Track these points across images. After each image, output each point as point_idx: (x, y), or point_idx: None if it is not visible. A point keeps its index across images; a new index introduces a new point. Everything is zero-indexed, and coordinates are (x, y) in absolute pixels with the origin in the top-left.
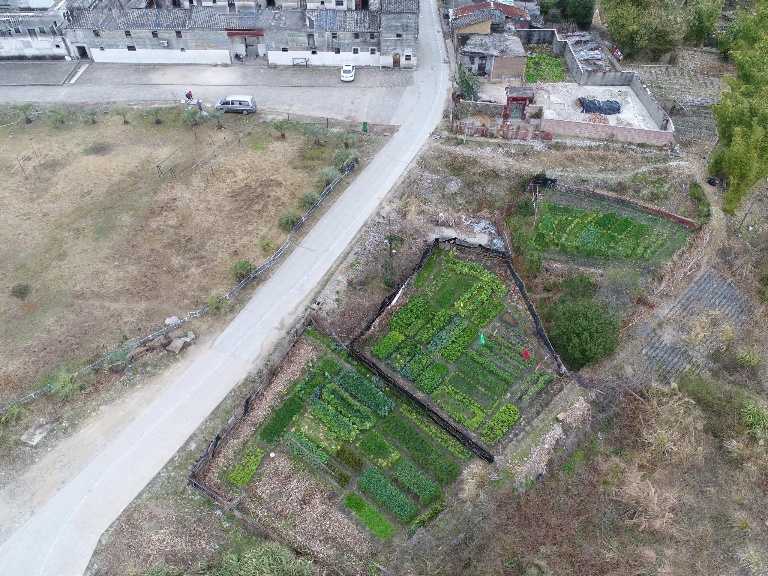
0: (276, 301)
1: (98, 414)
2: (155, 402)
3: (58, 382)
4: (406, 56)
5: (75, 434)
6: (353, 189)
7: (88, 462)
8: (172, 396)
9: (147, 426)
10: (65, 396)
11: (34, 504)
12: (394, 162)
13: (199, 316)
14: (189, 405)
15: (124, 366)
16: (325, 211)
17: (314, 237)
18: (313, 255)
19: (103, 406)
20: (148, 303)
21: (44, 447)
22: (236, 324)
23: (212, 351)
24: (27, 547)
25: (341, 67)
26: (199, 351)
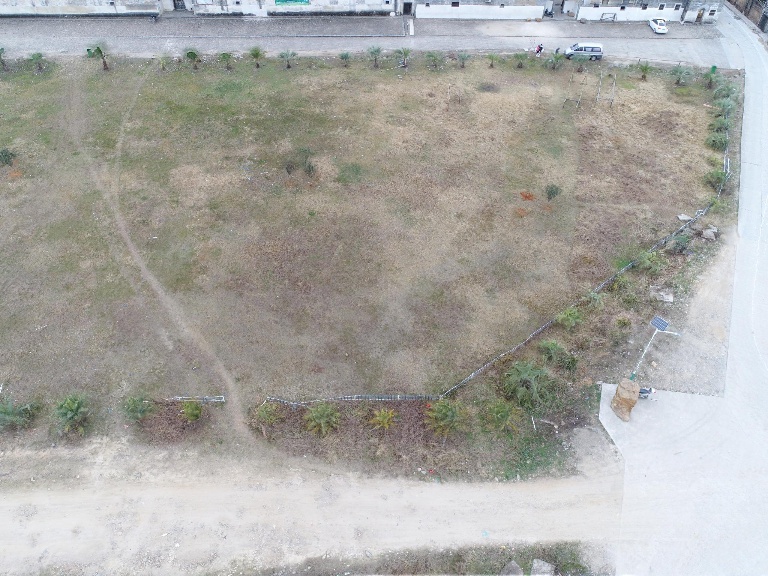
0: (762, 203)
1: (701, 281)
2: (736, 274)
3: (643, 259)
4: (711, 11)
5: (696, 295)
6: (749, 118)
7: (729, 314)
8: (745, 270)
9: (748, 290)
10: (654, 270)
11: (720, 341)
12: (766, 98)
13: (704, 214)
14: (765, 276)
15: (680, 249)
16: (738, 136)
17: (749, 155)
18: (762, 168)
19: (699, 276)
20: (649, 205)
21: (681, 304)
22: (744, 219)
23: (743, 239)
24: (748, 368)
25: (645, 22)
26: (732, 239)
